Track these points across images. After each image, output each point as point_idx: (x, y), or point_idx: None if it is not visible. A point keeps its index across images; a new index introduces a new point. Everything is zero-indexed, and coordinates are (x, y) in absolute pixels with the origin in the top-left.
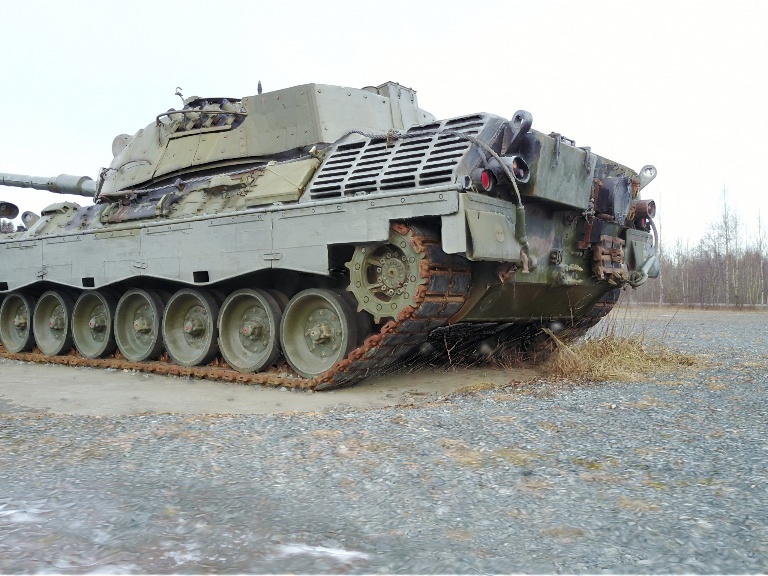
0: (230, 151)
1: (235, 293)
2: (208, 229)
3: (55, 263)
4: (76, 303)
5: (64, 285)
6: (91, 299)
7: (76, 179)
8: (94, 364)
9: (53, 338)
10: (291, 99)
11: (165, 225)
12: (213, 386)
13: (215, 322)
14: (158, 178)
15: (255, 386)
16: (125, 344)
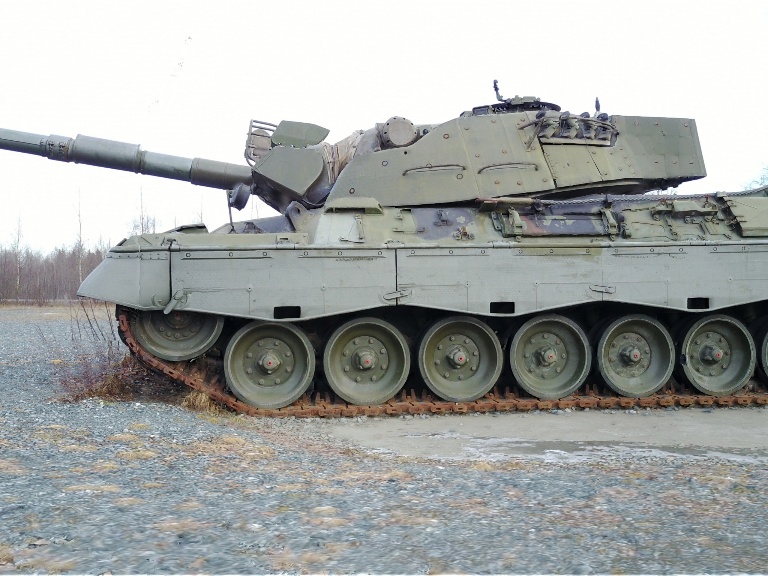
0: (625, 170)
1: (708, 319)
2: (709, 255)
3: (430, 282)
4: (430, 333)
5: (447, 311)
6: (450, 328)
7: (129, 147)
8: (506, 408)
9: (351, 382)
10: (673, 128)
11: (645, 247)
12: (743, 412)
13: (678, 349)
14: (561, 188)
15: (767, 407)
16: (524, 380)
